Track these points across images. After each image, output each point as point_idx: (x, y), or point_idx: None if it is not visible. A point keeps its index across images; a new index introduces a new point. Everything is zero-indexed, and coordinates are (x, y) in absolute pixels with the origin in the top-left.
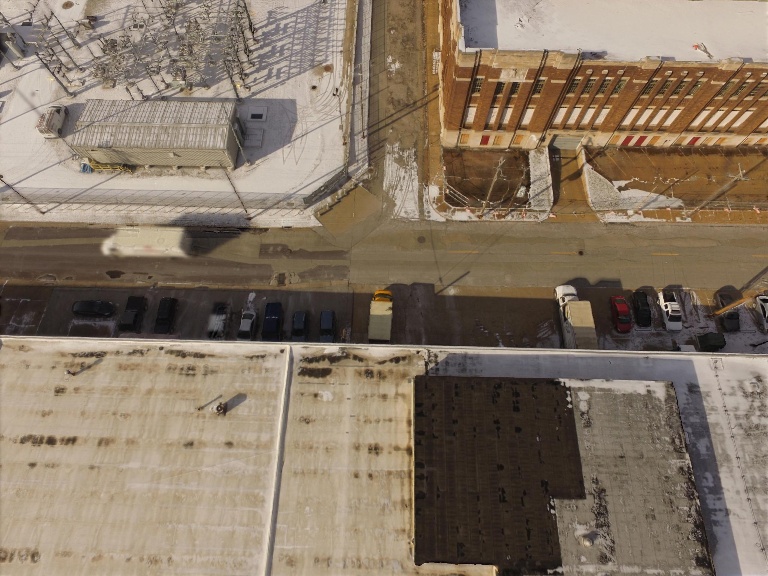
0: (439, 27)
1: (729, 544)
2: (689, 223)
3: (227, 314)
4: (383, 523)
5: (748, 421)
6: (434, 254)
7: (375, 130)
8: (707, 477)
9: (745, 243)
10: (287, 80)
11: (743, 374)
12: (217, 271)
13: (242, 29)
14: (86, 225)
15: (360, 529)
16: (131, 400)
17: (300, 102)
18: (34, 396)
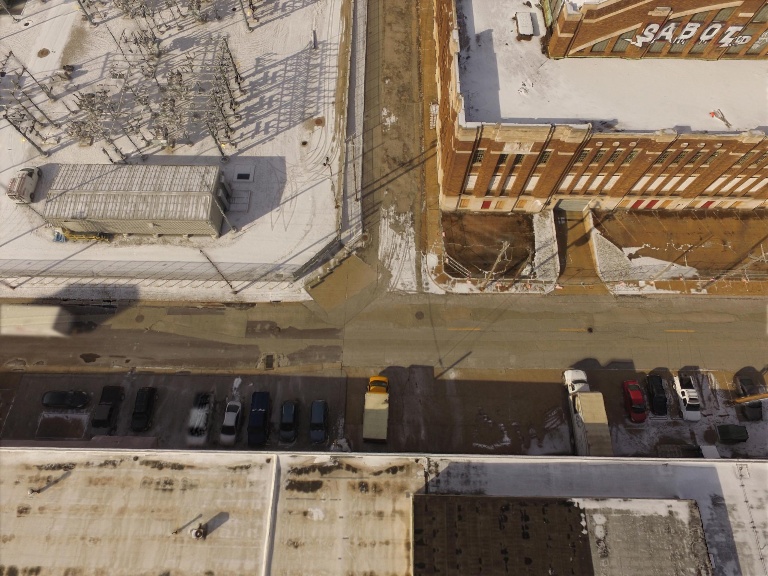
0: (436, 77)
1: None
2: (705, 295)
3: (210, 404)
4: None
5: None
6: (433, 332)
7: (369, 192)
8: None
9: (765, 318)
10: (276, 135)
11: None
12: (200, 353)
13: (228, 81)
14: (59, 301)
15: None
16: (101, 521)
17: (289, 160)
18: None
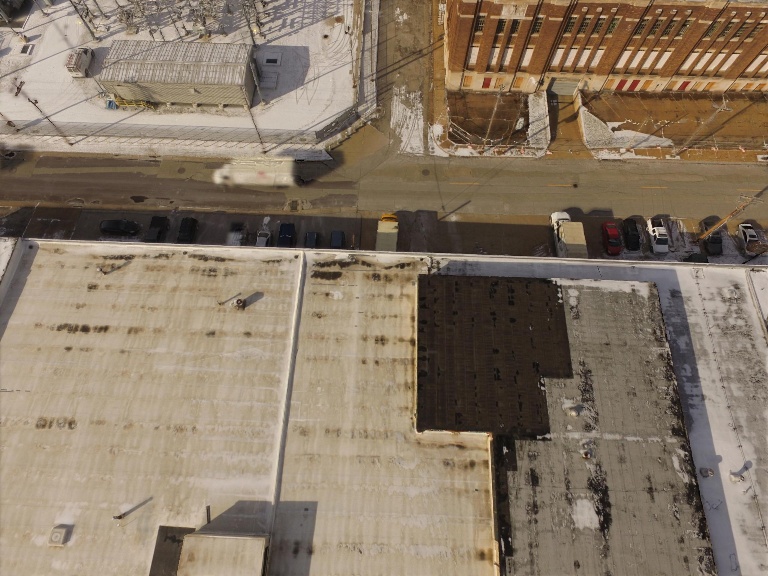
0: None
1: (704, 424)
2: (678, 160)
3: (244, 235)
4: (388, 402)
5: (725, 322)
6: (437, 185)
7: (383, 74)
8: (686, 368)
9: (730, 179)
10: (300, 29)
11: (722, 282)
12: (234, 197)
13: None
14: (111, 156)
15: (367, 406)
16: (158, 296)
17: (312, 49)
18: (69, 291)
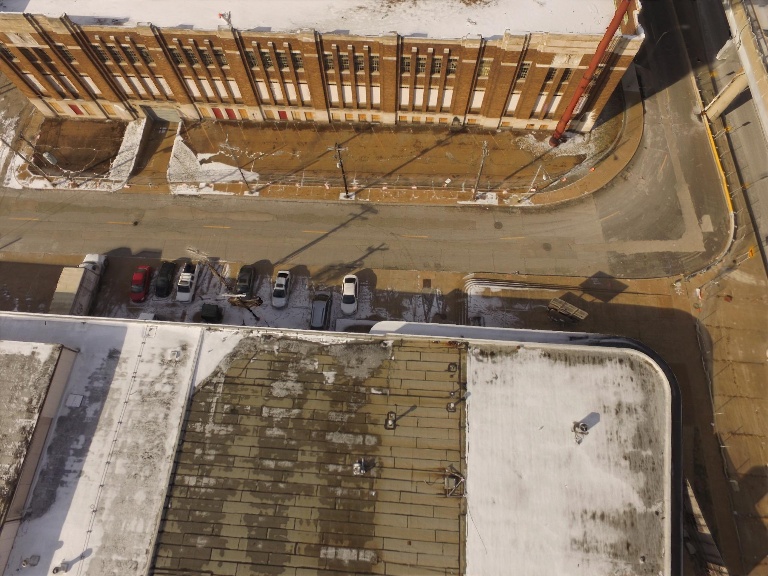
0: None
1: (64, 504)
2: (255, 197)
3: None
4: None
5: (150, 388)
6: None
7: None
8: (79, 440)
9: (301, 218)
10: None
11: (171, 342)
12: None
13: None
14: None
15: None
16: None
17: None
18: None
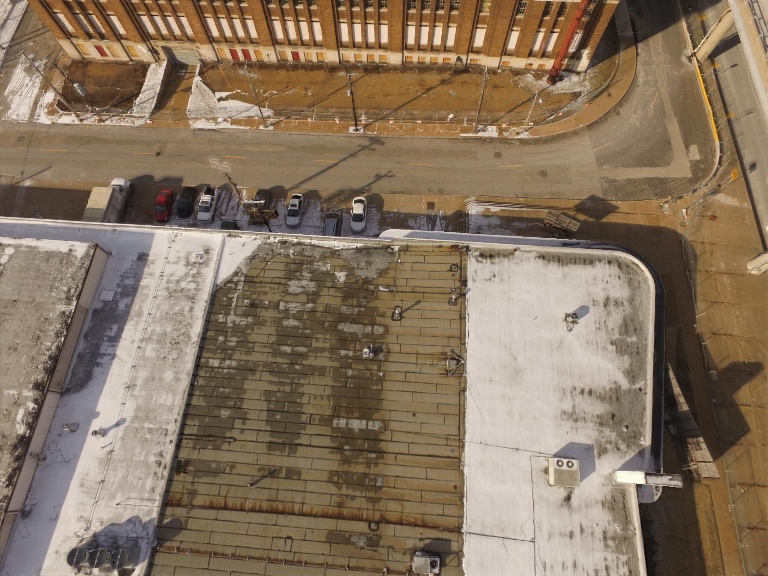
0: None
1: (100, 381)
2: (270, 131)
3: None
4: None
5: (177, 285)
6: (27, 151)
7: (17, 43)
8: (112, 328)
9: (313, 149)
10: None
11: (195, 247)
12: None
13: None
14: None
15: None
16: None
17: None
18: None
